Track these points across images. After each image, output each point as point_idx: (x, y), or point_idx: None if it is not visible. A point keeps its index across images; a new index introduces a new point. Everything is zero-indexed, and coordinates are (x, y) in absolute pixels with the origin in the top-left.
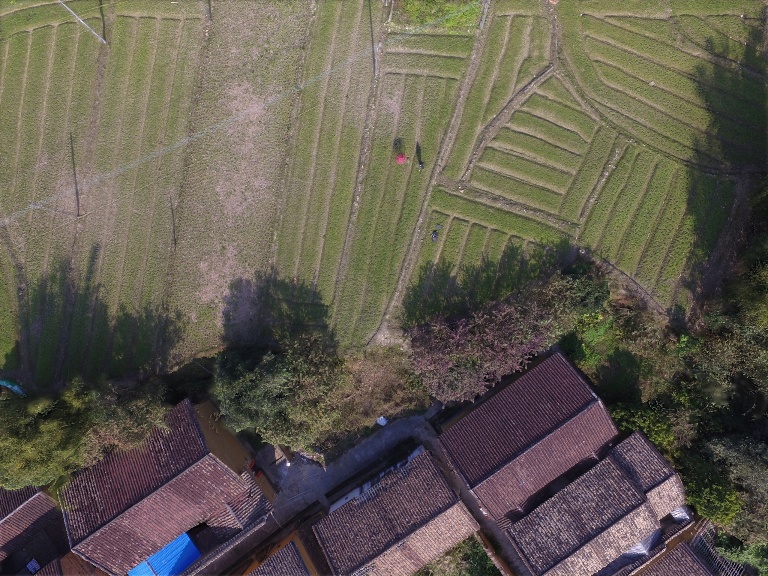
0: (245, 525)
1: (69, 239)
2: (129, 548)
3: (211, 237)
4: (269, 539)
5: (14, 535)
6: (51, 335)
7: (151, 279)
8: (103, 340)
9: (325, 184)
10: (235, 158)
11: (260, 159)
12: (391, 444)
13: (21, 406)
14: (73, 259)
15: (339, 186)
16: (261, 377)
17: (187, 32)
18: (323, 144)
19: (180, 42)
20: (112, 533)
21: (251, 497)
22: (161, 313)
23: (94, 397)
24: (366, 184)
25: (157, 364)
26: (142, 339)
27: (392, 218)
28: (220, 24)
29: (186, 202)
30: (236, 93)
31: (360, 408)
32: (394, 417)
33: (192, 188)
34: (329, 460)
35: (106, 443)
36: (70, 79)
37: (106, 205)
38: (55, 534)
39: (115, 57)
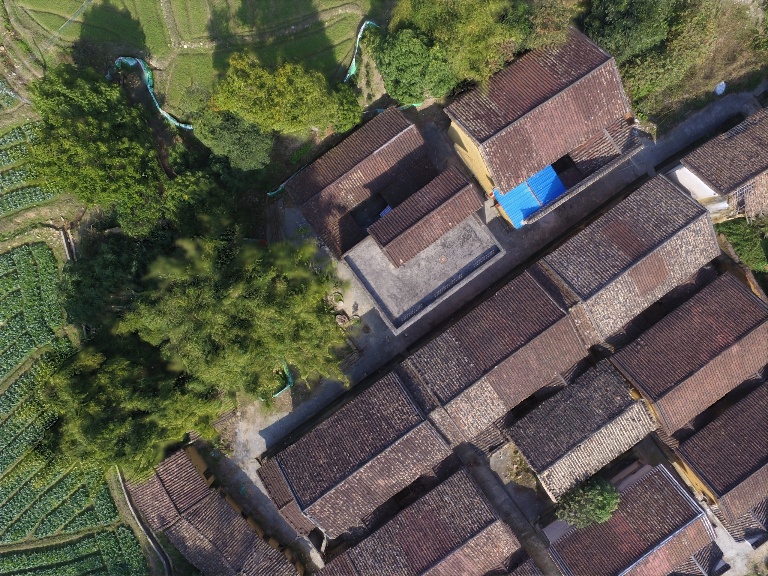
0: (622, 151)
1: None
2: (521, 159)
3: None
4: (597, 211)
5: (382, 171)
6: None
7: None
8: None
9: None
10: None
11: None
12: (721, 119)
13: None
14: None
15: None
16: None
17: None
18: None
19: None
20: (514, 135)
21: (623, 128)
22: None
23: None
24: None
25: None
26: None
27: None
28: None
29: None
30: None
31: (701, 73)
32: (728, 89)
33: None
34: (660, 132)
35: (504, 54)
36: None
37: None
38: (416, 176)
39: None
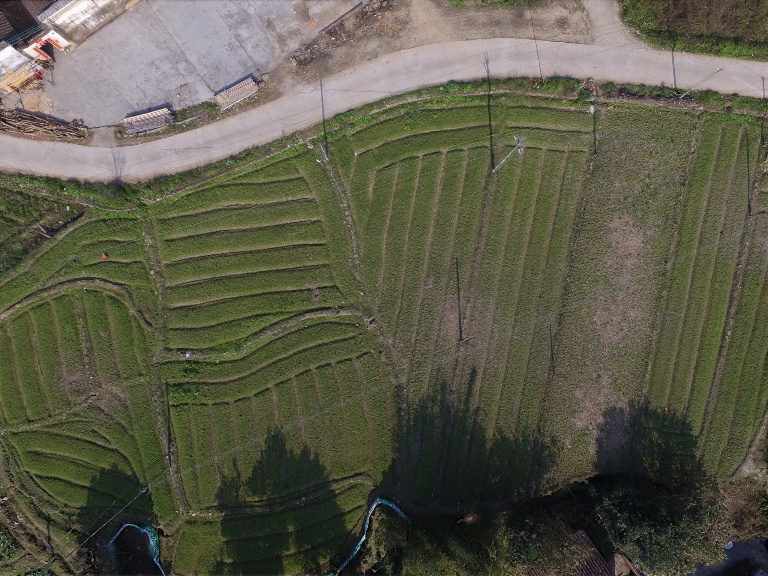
0: None
1: (451, 362)
2: None
3: (587, 365)
4: None
5: None
6: (431, 455)
7: (529, 404)
8: (481, 462)
9: (698, 318)
10: (613, 289)
11: (637, 291)
12: (728, 565)
13: (475, 550)
14: (455, 382)
15: (712, 320)
16: (695, 526)
17: (572, 164)
18: (698, 279)
19: (564, 173)
20: None
21: None
22: (537, 438)
23: (522, 535)
24: (737, 319)
25: (532, 488)
26: (519, 463)
27: (761, 353)
28: (603, 158)
29: (565, 330)
30: (616, 225)
31: None
32: None
33: (571, 316)
34: None
35: None
36: (457, 205)
37: (487, 330)
38: None
39: (502, 186)
